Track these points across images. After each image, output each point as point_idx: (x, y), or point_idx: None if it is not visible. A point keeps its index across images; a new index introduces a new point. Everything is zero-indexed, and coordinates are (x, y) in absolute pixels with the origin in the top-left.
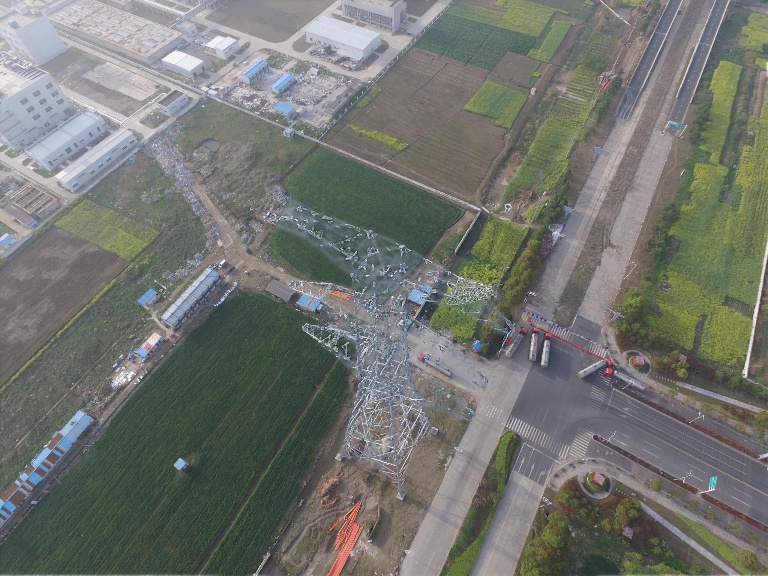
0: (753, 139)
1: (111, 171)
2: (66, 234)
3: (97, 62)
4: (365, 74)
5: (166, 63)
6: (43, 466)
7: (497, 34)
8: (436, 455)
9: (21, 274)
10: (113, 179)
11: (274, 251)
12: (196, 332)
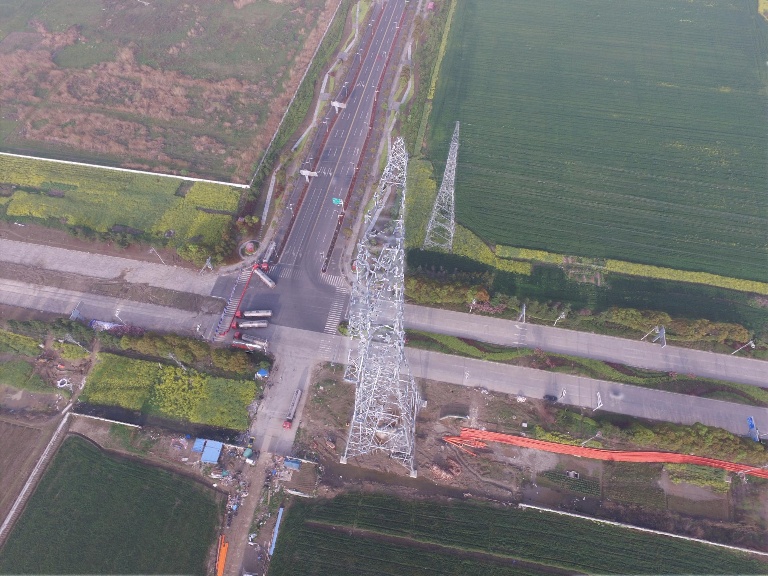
0: None
1: None
2: None
3: None
4: None
5: None
6: None
7: None
8: None
9: None
10: None
11: None
12: None
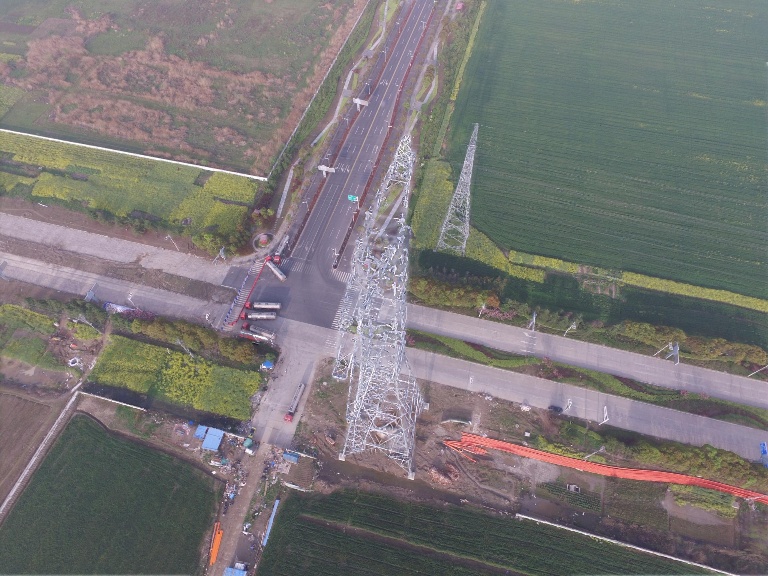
0: (5, 153)
1: None
2: None
3: None
4: None
5: None
6: None
7: None
8: None
9: None
10: None
11: None
12: None
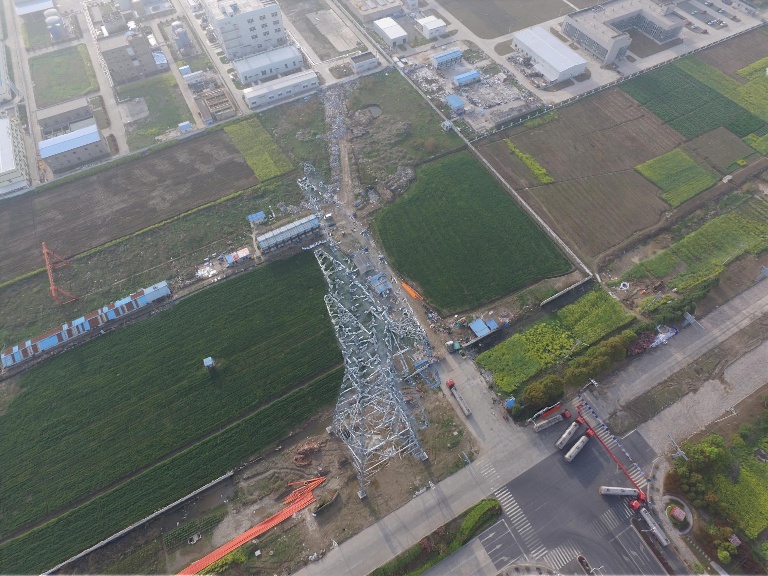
0: None
1: (286, 102)
2: (228, 139)
3: (323, 7)
4: (550, 96)
5: (376, 25)
6: (121, 309)
7: (720, 104)
8: (413, 479)
9: (182, 157)
10: (284, 109)
11: (375, 225)
12: (277, 263)
